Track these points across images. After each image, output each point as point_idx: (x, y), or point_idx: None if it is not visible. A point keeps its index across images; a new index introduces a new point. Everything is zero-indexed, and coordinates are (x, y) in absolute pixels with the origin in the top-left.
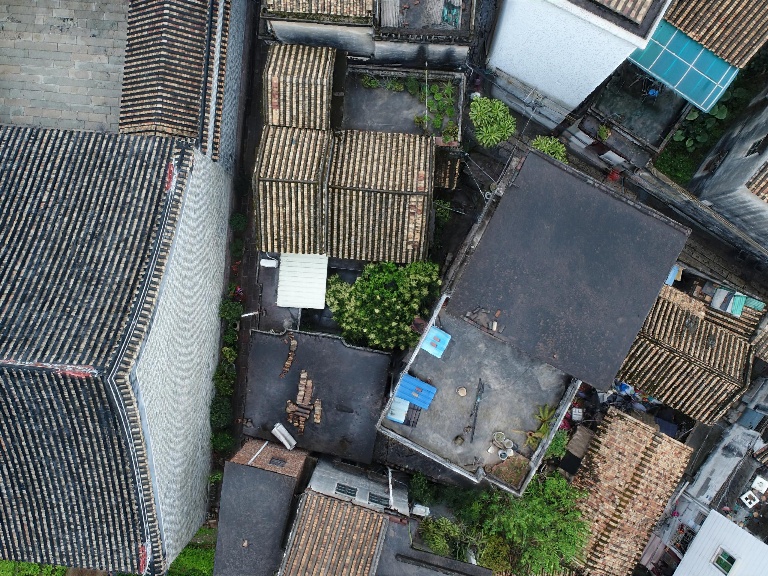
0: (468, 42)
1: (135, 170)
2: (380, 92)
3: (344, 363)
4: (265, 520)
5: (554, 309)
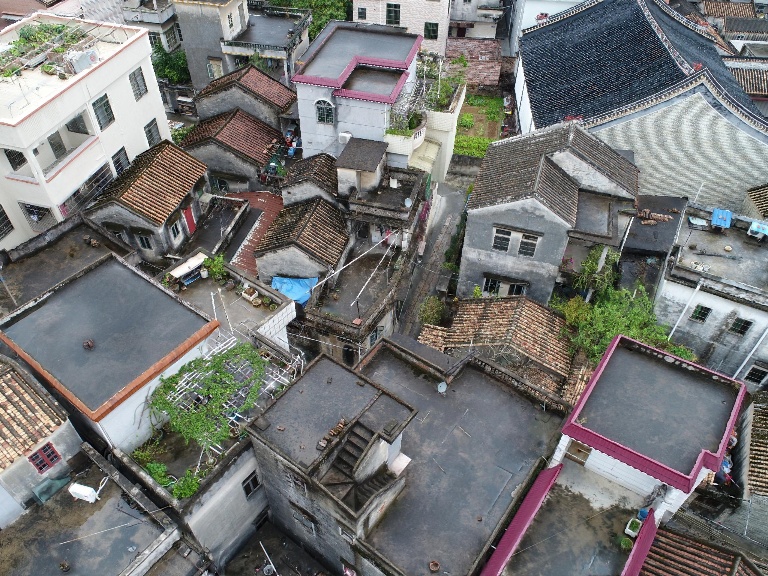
0: None
1: None
2: None
3: None
4: None
5: None
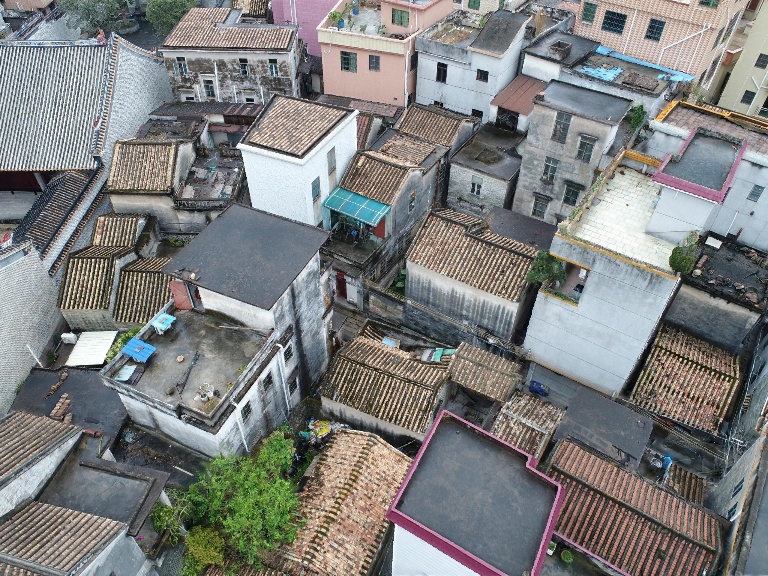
0: None
1: None
2: None
3: (103, 387)
4: None
5: (237, 268)
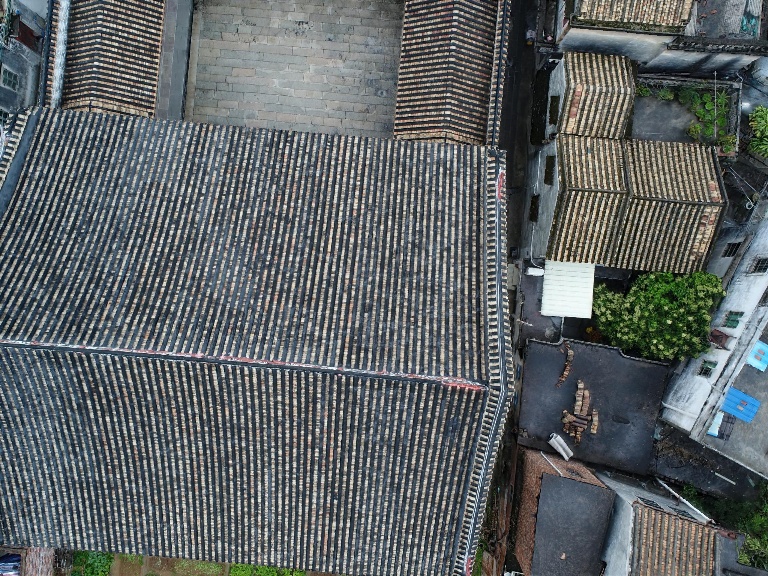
0: (765, 52)
1: (440, 178)
2: (648, 100)
3: (620, 373)
4: (583, 533)
5: None
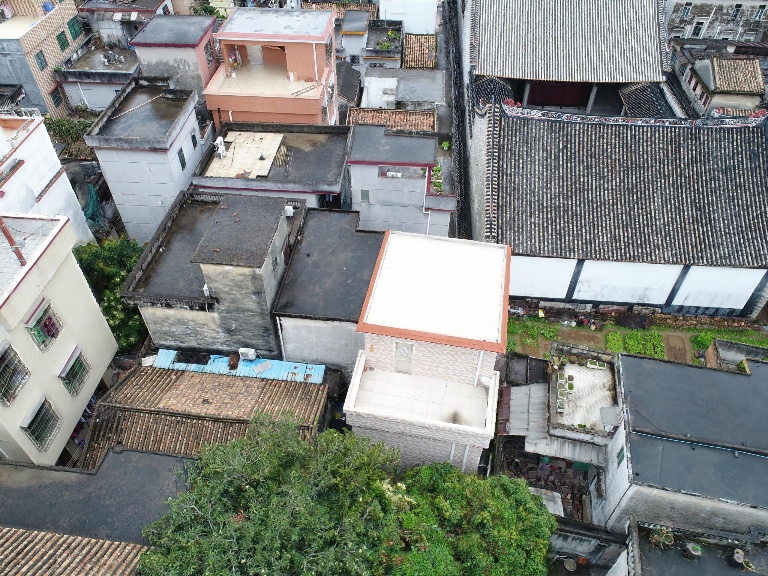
0: None
1: None
2: None
3: None
4: None
5: None
